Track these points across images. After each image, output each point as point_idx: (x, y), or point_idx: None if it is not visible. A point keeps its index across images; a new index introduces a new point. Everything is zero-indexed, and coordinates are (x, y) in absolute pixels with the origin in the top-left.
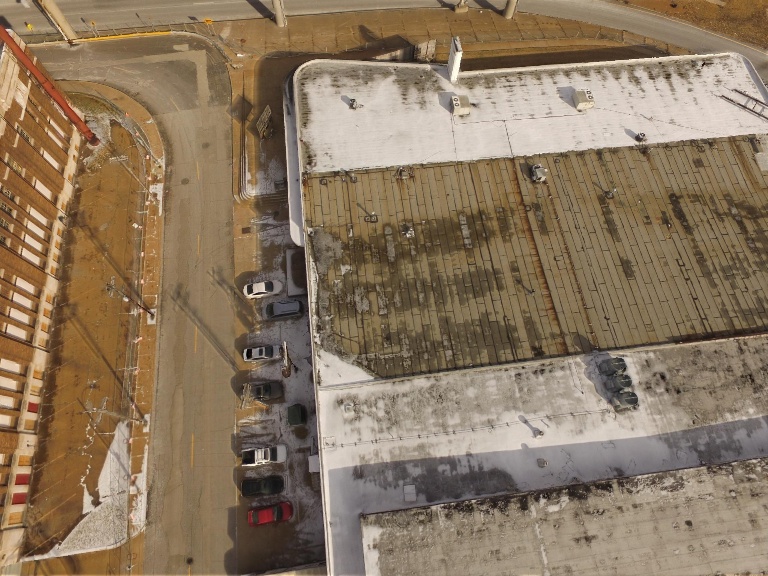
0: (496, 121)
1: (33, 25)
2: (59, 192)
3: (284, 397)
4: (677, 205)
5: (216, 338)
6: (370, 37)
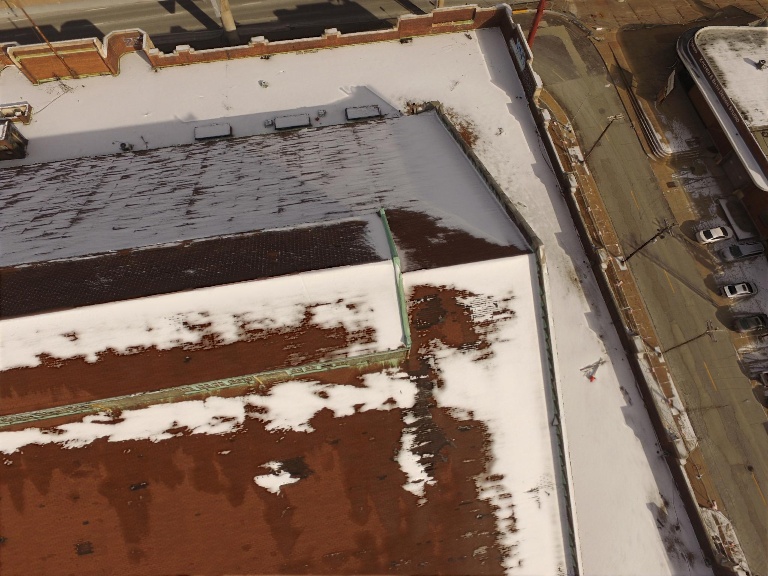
0: None
1: (390, 9)
2: None
3: None
4: None
5: (686, 279)
6: (708, 8)
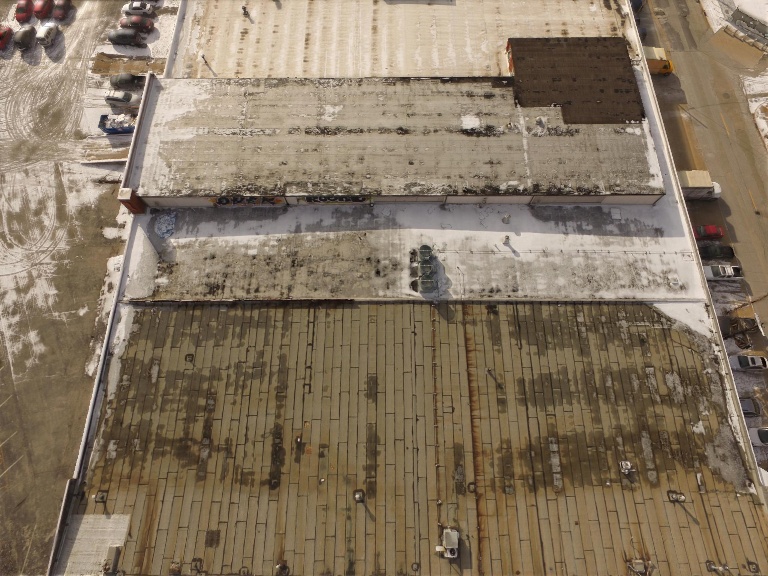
0: None
1: None
2: None
3: None
4: (275, 470)
5: None
6: None
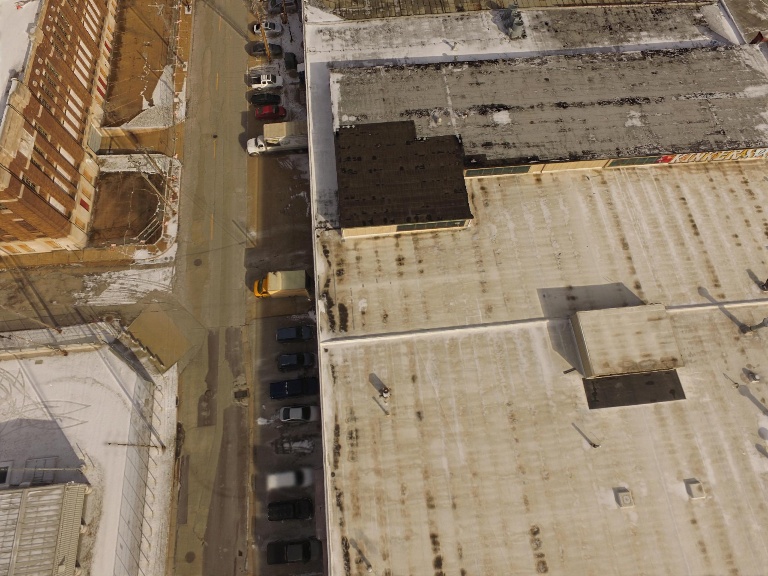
0: None
1: None
2: None
3: (282, 55)
4: None
5: (234, 23)
6: None
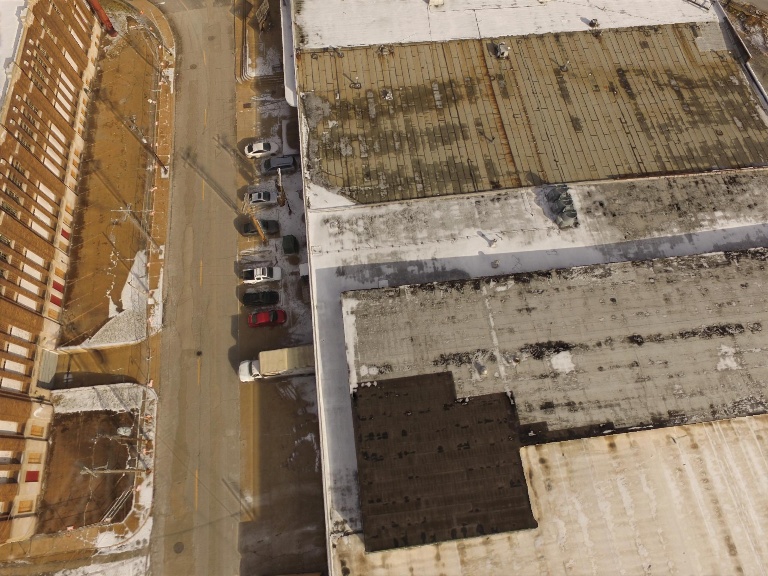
0: (467, 10)
1: None
2: (84, 68)
3: (279, 233)
4: (623, 77)
5: (221, 189)
6: None
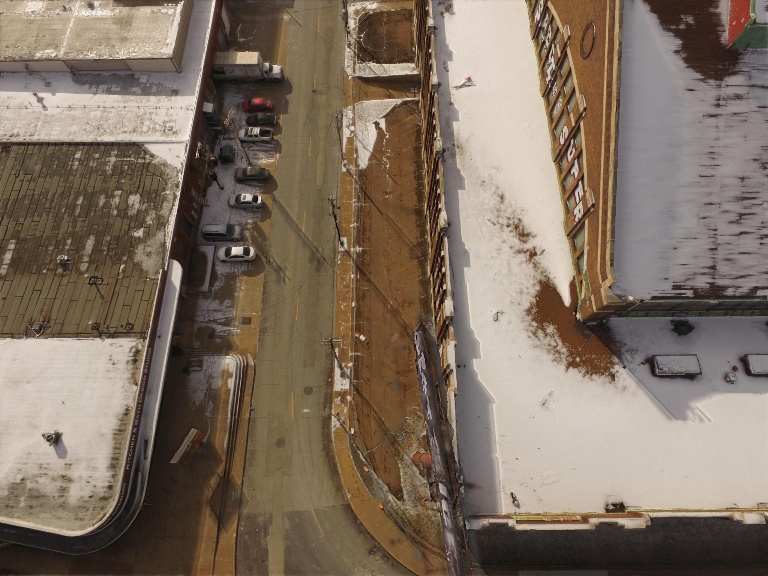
0: None
1: None
2: None
3: None
4: None
5: (287, 221)
6: None
